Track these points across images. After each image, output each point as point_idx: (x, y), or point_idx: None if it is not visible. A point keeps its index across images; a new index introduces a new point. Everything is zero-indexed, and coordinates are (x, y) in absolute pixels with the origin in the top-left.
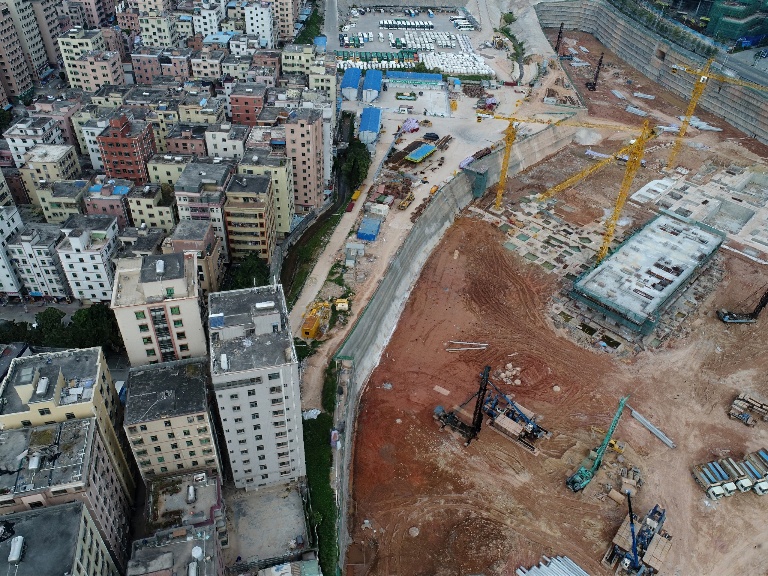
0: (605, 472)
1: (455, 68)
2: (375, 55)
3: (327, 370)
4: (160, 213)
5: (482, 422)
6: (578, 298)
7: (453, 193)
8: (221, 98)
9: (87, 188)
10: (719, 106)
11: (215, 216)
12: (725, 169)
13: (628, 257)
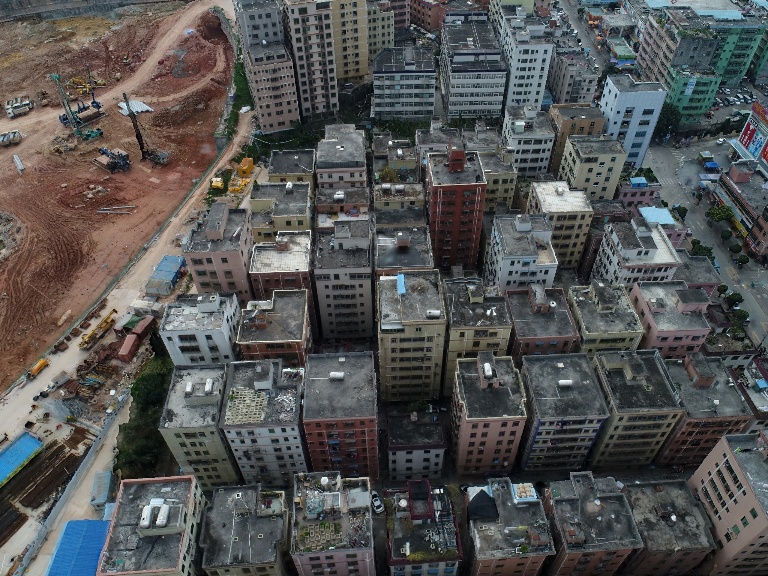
0: (74, 143)
1: None
2: None
3: None
4: None
5: (135, 164)
6: None
7: None
8: (383, 327)
9: None
10: None
11: None
12: None
13: None
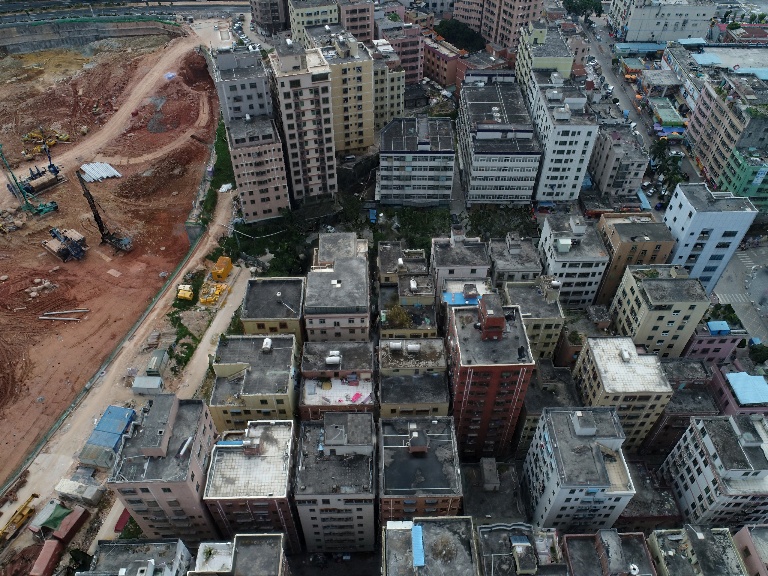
0: (22, 219)
1: None
2: None
3: None
4: None
5: (93, 250)
6: None
7: None
8: None
9: None
10: None
11: None
12: None
13: None
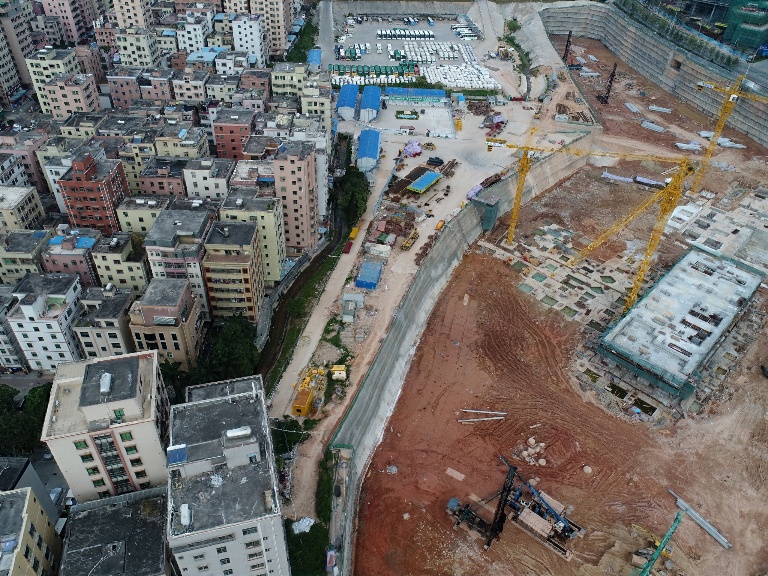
0: None
1: (458, 82)
2: (373, 69)
3: (322, 463)
4: (130, 269)
5: None
6: (606, 354)
7: (461, 227)
8: None
9: (47, 239)
10: (741, 120)
11: (193, 272)
12: (753, 192)
13: (659, 303)
